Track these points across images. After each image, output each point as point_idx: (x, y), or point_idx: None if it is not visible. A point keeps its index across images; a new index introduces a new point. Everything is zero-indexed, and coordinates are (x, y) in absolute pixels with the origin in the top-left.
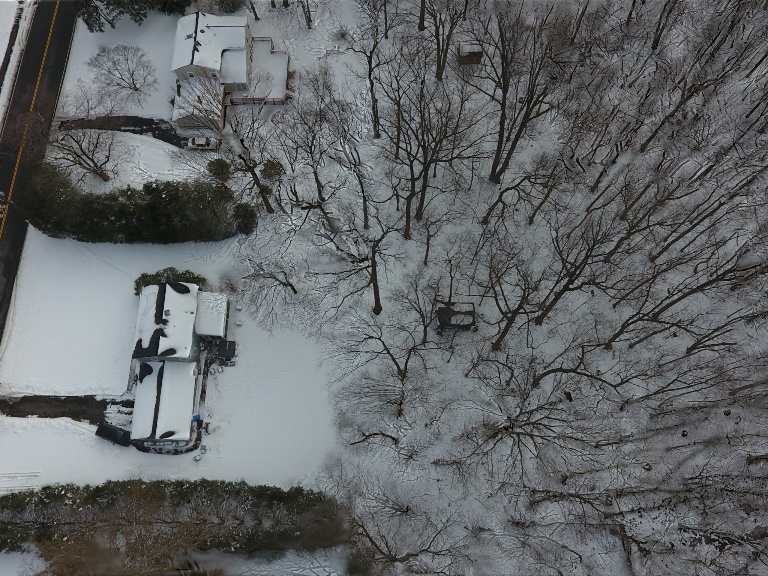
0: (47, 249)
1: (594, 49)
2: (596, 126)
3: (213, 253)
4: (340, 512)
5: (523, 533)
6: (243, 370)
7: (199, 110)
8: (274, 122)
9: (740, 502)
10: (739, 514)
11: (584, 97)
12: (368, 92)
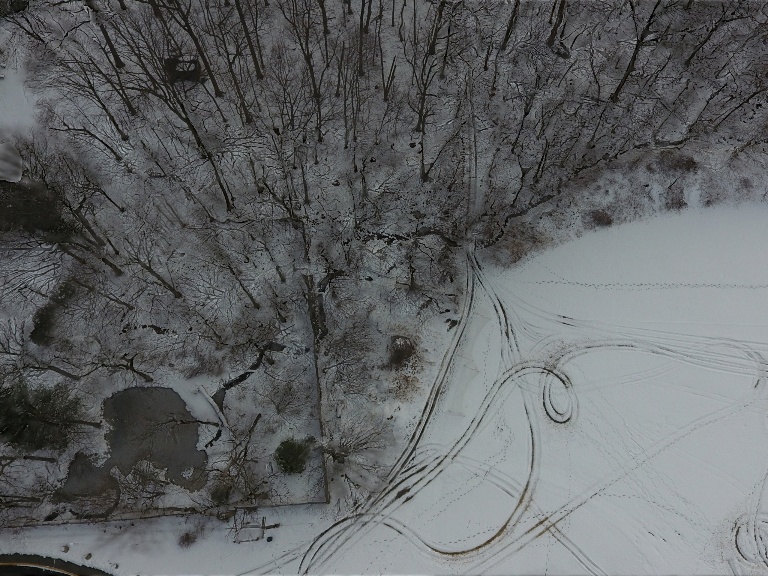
0: None
1: None
2: None
3: None
4: (51, 195)
5: (217, 226)
6: (0, 111)
7: None
8: None
9: (411, 209)
10: (408, 217)
11: None
12: None
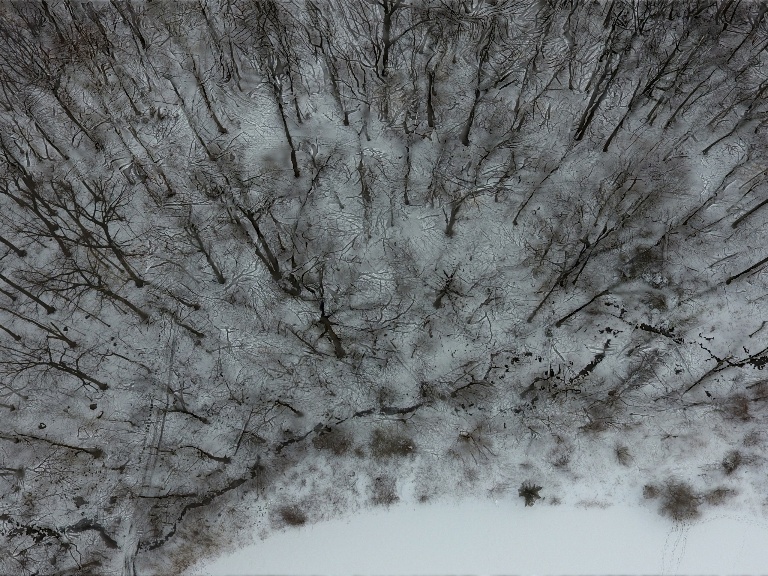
0: None
1: (85, 47)
2: (5, 121)
3: None
4: None
5: None
6: None
7: None
8: None
9: (74, 495)
10: (67, 506)
11: None
12: None
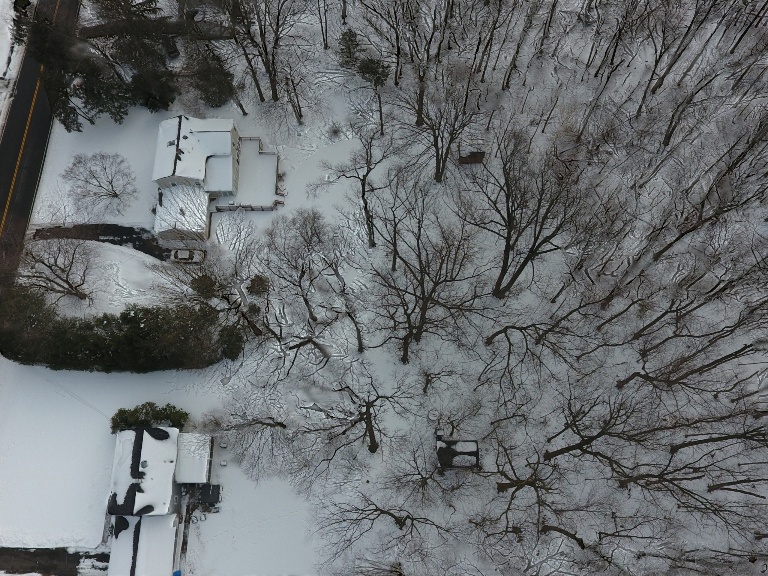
0: (18, 376)
1: (602, 145)
2: (606, 243)
3: (196, 382)
4: None
5: None
6: (228, 517)
7: (182, 223)
8: (259, 258)
9: None
10: None
11: (592, 199)
12: (362, 211)
